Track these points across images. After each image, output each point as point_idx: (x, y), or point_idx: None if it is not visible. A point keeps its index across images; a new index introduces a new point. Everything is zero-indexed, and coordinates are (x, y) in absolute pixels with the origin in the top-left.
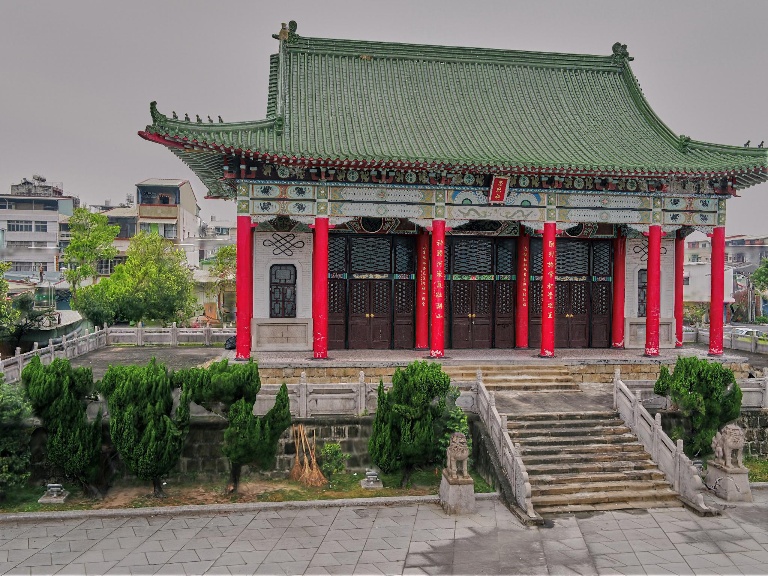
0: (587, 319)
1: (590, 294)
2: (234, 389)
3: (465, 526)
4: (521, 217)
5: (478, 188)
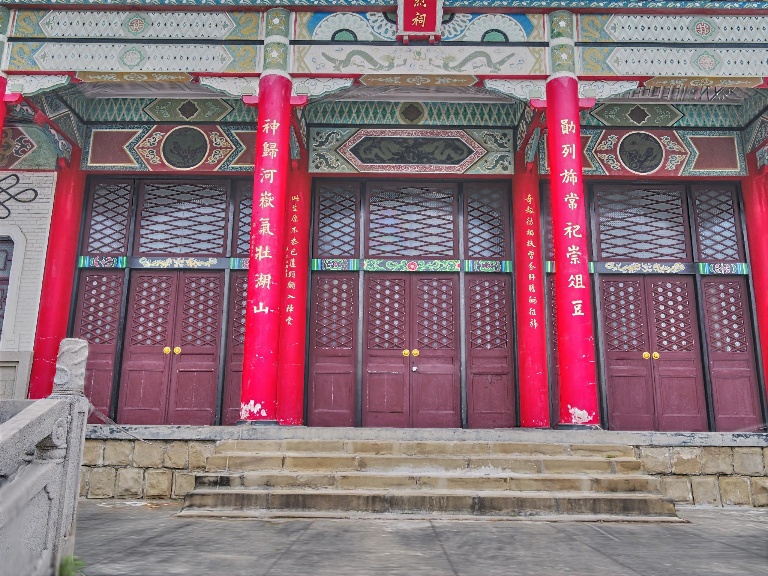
0: (697, 364)
1: (697, 303)
2: None
3: None
4: (484, 67)
5: (369, 1)
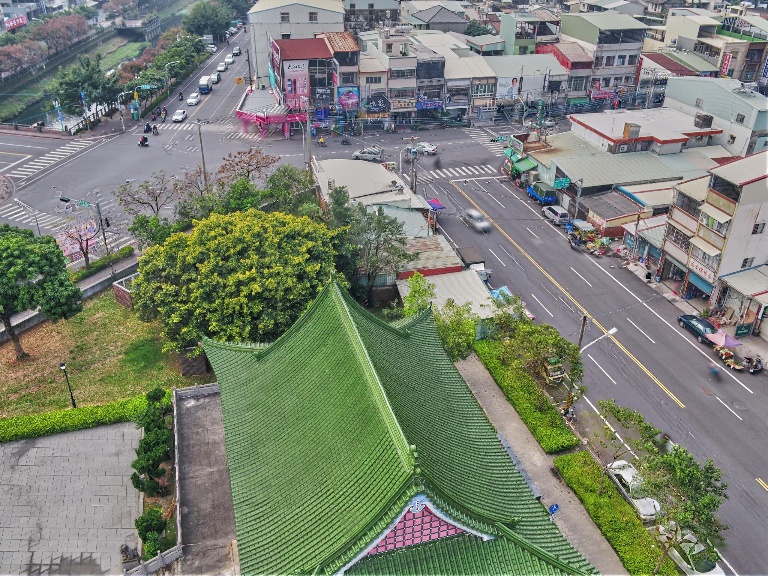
0: None
1: None
2: (134, 468)
3: (111, 568)
4: None
5: None
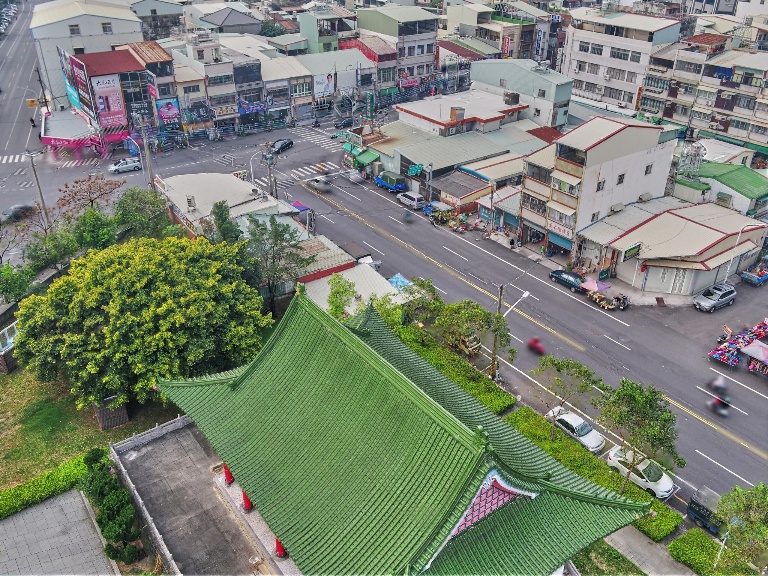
0: None
1: None
2: (107, 538)
3: None
4: None
5: None
